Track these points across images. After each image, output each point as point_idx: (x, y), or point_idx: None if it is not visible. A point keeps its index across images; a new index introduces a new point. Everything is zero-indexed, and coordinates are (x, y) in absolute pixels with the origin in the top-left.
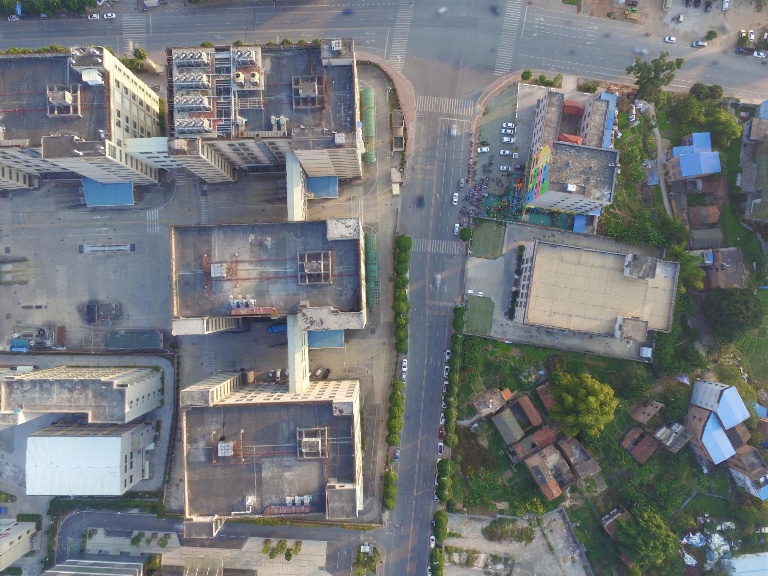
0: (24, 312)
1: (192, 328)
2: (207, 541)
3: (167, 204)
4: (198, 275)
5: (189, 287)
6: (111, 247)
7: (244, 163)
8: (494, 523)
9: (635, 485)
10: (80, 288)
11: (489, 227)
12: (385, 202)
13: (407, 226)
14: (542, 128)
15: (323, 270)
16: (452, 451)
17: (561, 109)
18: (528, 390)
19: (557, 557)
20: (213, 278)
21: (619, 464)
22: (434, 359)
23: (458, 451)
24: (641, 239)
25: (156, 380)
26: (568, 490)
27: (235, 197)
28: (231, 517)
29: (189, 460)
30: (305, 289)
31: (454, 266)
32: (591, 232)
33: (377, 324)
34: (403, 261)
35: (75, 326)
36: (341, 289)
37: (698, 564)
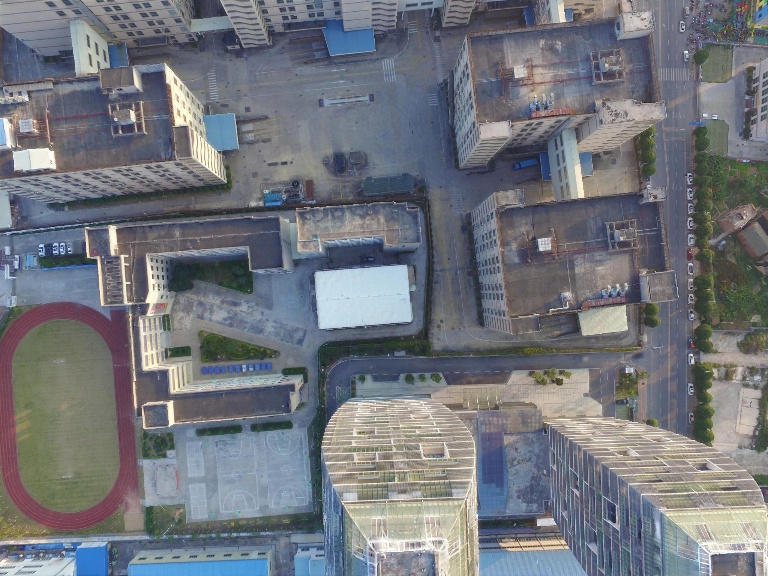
0: (270, 169)
1: (499, 131)
2: (473, 378)
3: (402, 52)
4: (494, 82)
5: (486, 95)
6: (350, 99)
7: None
8: (749, 336)
9: None
10: (323, 141)
11: (717, 52)
12: None
13: None
14: None
15: None
16: (702, 270)
17: None
18: (767, 206)
19: None
20: (509, 84)
21: None
22: (676, 183)
23: (709, 269)
24: None
25: None
26: None
27: None
28: None
29: (504, 262)
30: (598, 89)
31: (686, 92)
32: None
33: (617, 154)
34: None
35: (322, 179)
36: (633, 86)
37: None
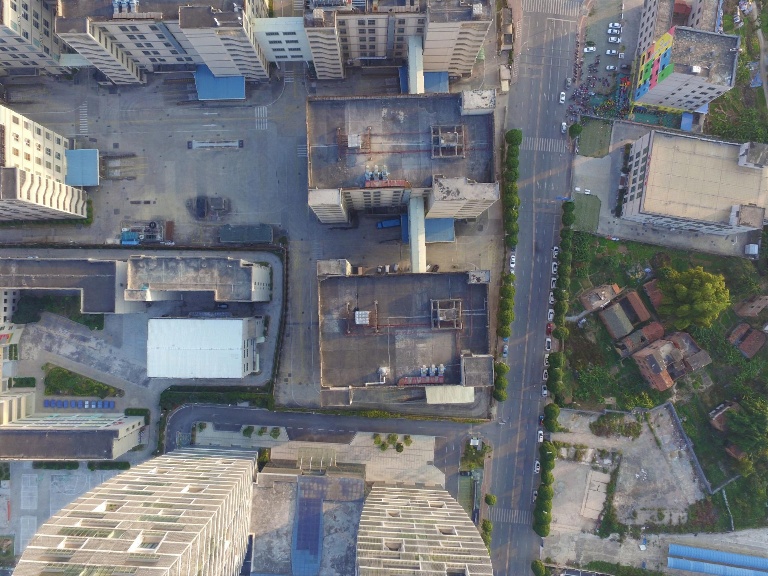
0: (132, 207)
1: (328, 198)
2: (316, 435)
3: (275, 101)
4: (331, 148)
5: (322, 160)
6: (219, 143)
7: (358, 55)
8: (602, 418)
9: (743, 379)
10: (188, 184)
11: (596, 126)
12: None
13: (514, 124)
14: (654, 22)
15: None
16: (560, 347)
17: (673, 4)
18: (634, 287)
19: (664, 452)
20: (346, 151)
21: (726, 359)
22: (541, 256)
23: (566, 346)
24: (748, 136)
25: (267, 273)
26: (674, 386)
27: None
28: (365, 387)
29: (323, 331)
30: (437, 163)
31: (561, 164)
32: (698, 130)
33: (485, 221)
34: (515, 155)
35: (183, 221)
36: (473, 163)
37: None
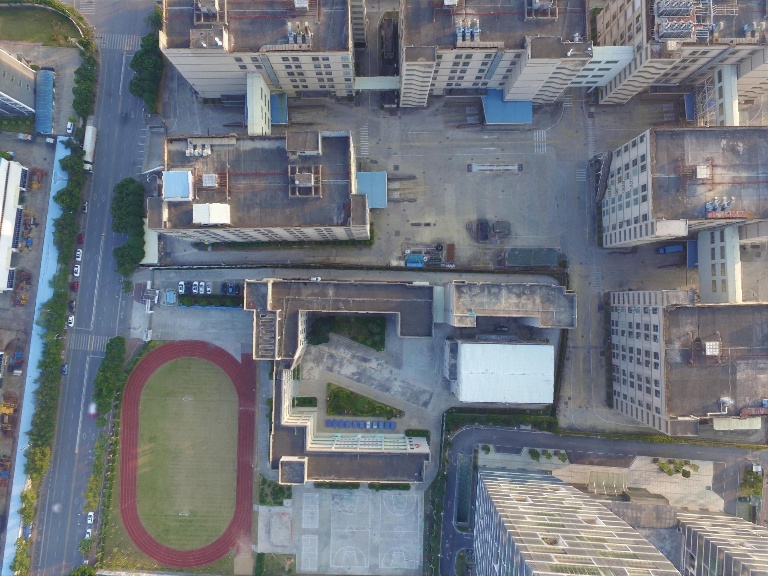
0: (413, 229)
1: (675, 229)
2: (596, 459)
3: (554, 125)
4: (672, 178)
5: (663, 190)
6: (499, 167)
7: (651, 82)
8: None
9: None
10: (468, 207)
11: None
12: None
13: None
14: None
15: None
16: None
17: None
18: None
19: None
20: (687, 182)
21: None
22: None
23: None
24: None
25: None
26: None
27: (622, 120)
28: None
29: None
30: None
31: None
32: None
33: (762, 247)
34: None
35: (464, 244)
36: None
37: None
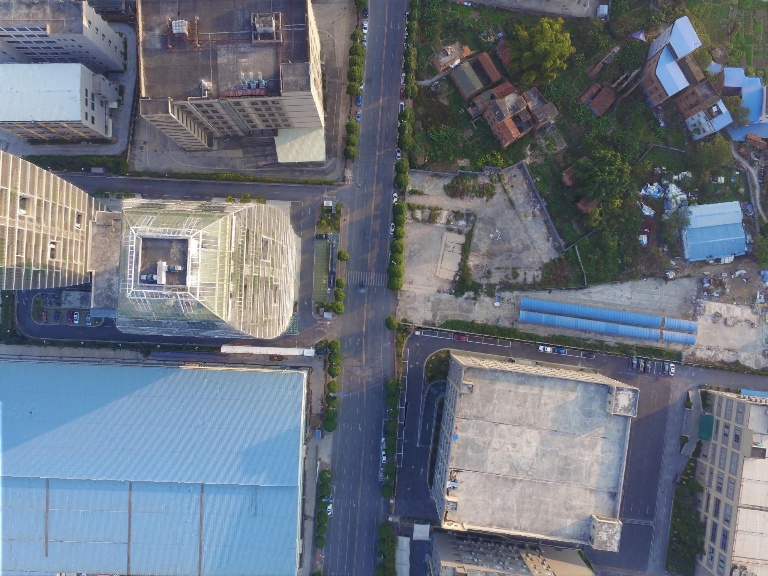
0: None
1: None
2: None
3: None
4: None
5: None
6: None
7: None
8: (455, 179)
9: (593, 136)
10: None
11: None
12: None
13: None
14: None
15: None
16: None
17: None
18: (487, 52)
19: (518, 212)
20: None
21: (577, 118)
22: (394, 22)
23: (419, 108)
24: None
25: (118, 38)
26: (528, 148)
27: None
28: (187, 101)
29: (145, 47)
30: None
31: None
32: None
33: None
34: None
35: None
36: None
37: (656, 216)
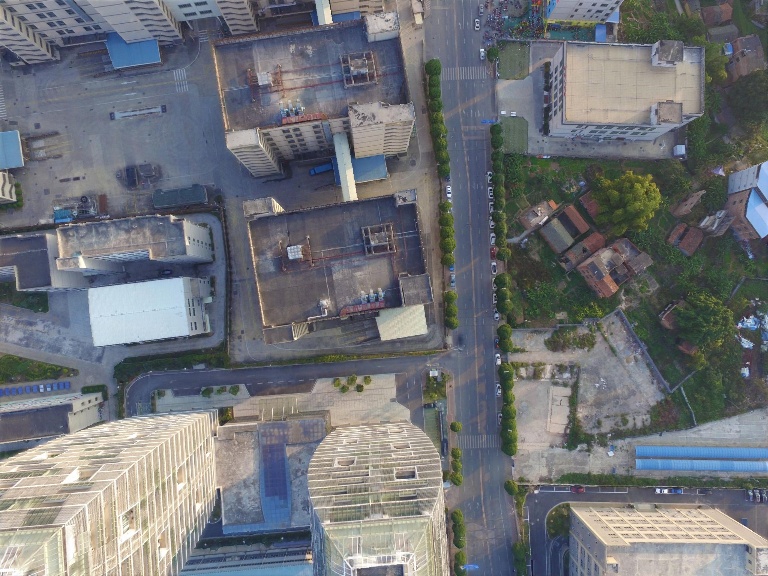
0: (62, 185)
1: (246, 139)
2: (276, 388)
3: (193, 62)
4: (244, 90)
5: (236, 103)
6: (142, 111)
7: (267, 4)
8: (555, 333)
9: (686, 277)
10: (116, 155)
11: (513, 48)
12: (409, 36)
13: (433, 57)
14: None
15: (367, 70)
16: None
17: None
18: (571, 202)
19: (620, 358)
20: (259, 91)
21: (668, 260)
22: (476, 183)
23: (512, 267)
24: (662, 39)
25: (206, 233)
26: (622, 293)
27: None
28: (308, 322)
29: (259, 272)
30: (352, 92)
31: (484, 90)
32: (612, 40)
33: (416, 156)
34: (436, 85)
35: (116, 193)
36: (387, 88)
37: (755, 347)
